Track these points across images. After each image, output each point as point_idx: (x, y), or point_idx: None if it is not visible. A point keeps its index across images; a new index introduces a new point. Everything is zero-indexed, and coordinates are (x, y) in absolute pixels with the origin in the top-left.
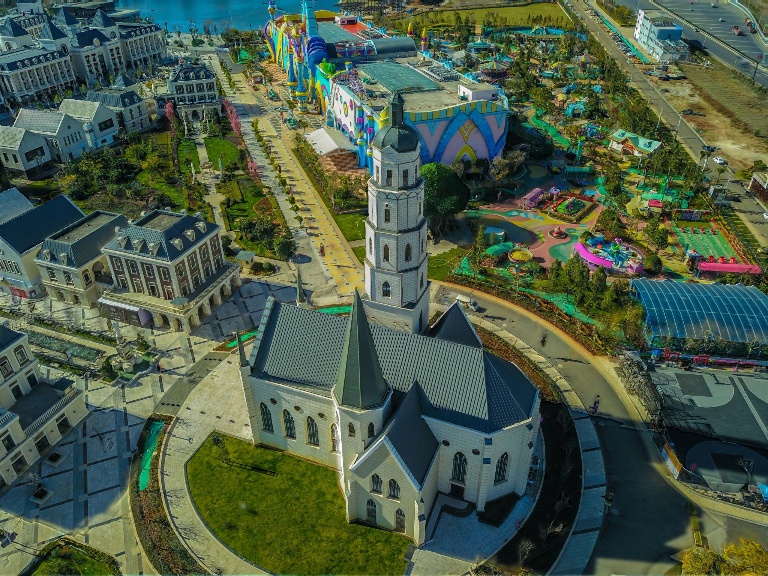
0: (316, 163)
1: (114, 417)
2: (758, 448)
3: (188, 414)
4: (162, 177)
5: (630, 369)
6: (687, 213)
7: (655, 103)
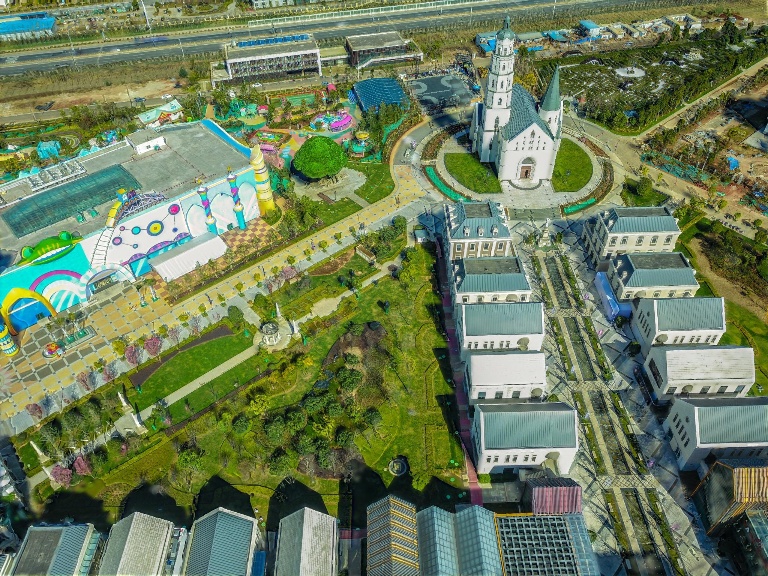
0: (215, 272)
1: (575, 228)
2: (452, 92)
3: (554, 203)
4: (295, 370)
5: (427, 113)
6: (269, 101)
7: (13, 120)
